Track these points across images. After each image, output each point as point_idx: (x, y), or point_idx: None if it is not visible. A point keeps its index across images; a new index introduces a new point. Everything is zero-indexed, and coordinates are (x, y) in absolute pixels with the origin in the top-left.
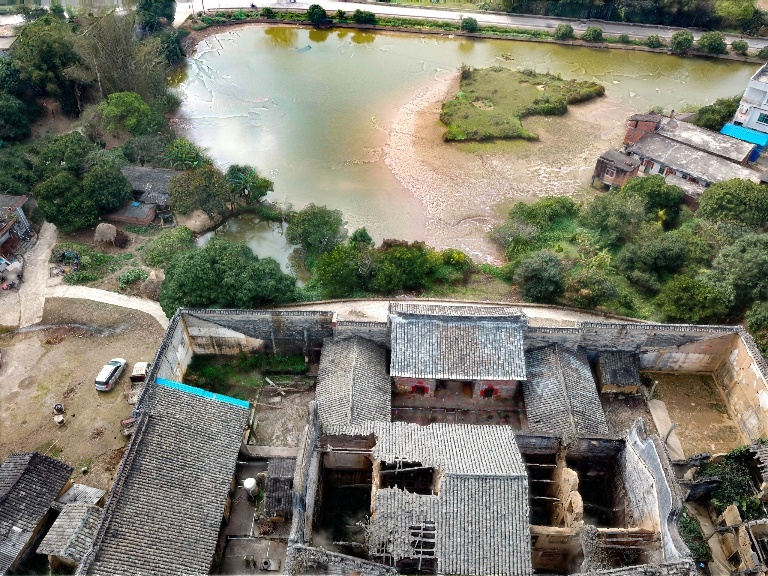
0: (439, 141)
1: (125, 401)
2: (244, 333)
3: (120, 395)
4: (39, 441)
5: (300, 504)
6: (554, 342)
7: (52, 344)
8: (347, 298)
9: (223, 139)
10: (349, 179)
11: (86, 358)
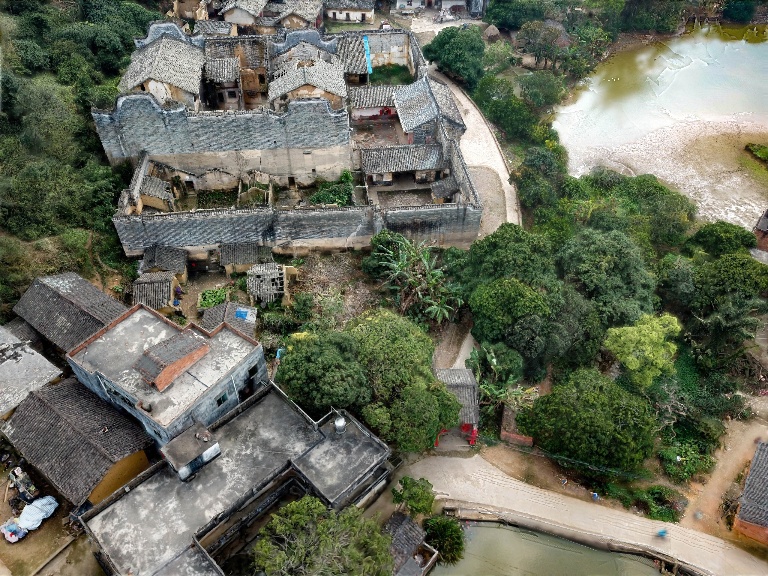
0: (744, 147)
1: None
2: None
3: None
4: None
5: None
6: None
7: None
8: None
9: (642, 56)
10: (633, 108)
11: None
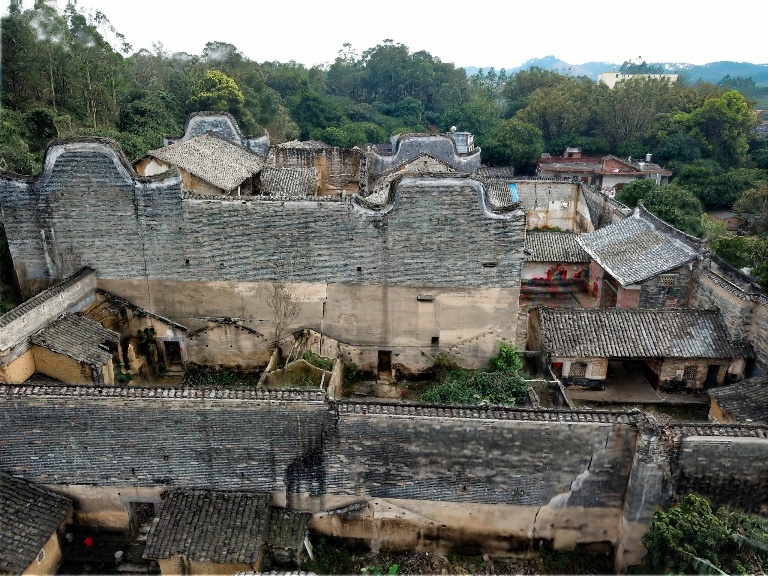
0: None
1: None
2: (591, 216)
3: None
4: None
5: (396, 148)
6: (718, 307)
7: None
8: None
9: None
10: None
11: None
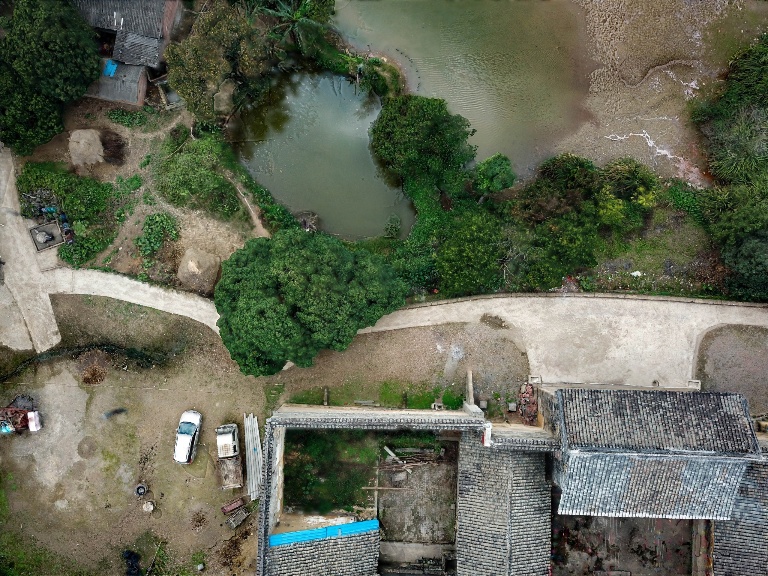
0: None
1: (217, 474)
2: None
3: (208, 465)
4: (136, 531)
5: None
6: None
7: (93, 384)
8: (478, 292)
9: None
10: None
11: (146, 407)
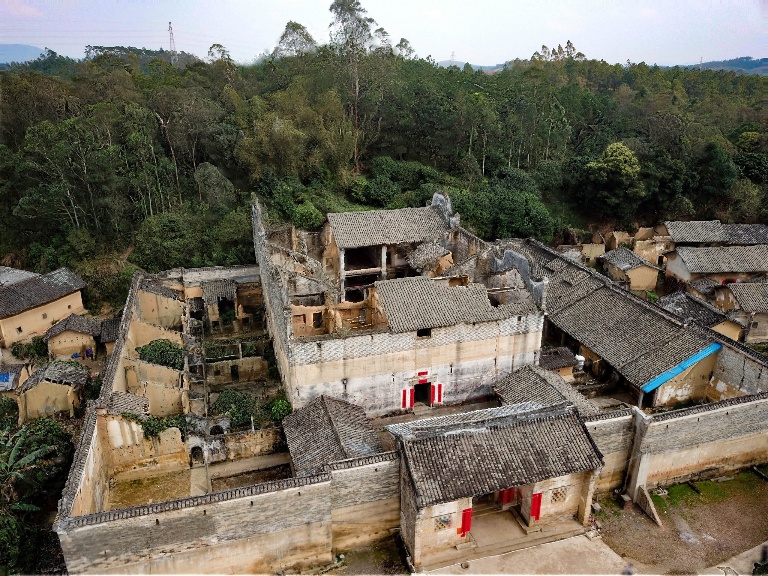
0: None
1: None
2: None
3: None
4: None
5: None
6: None
7: None
8: None
9: None
10: None
11: None
